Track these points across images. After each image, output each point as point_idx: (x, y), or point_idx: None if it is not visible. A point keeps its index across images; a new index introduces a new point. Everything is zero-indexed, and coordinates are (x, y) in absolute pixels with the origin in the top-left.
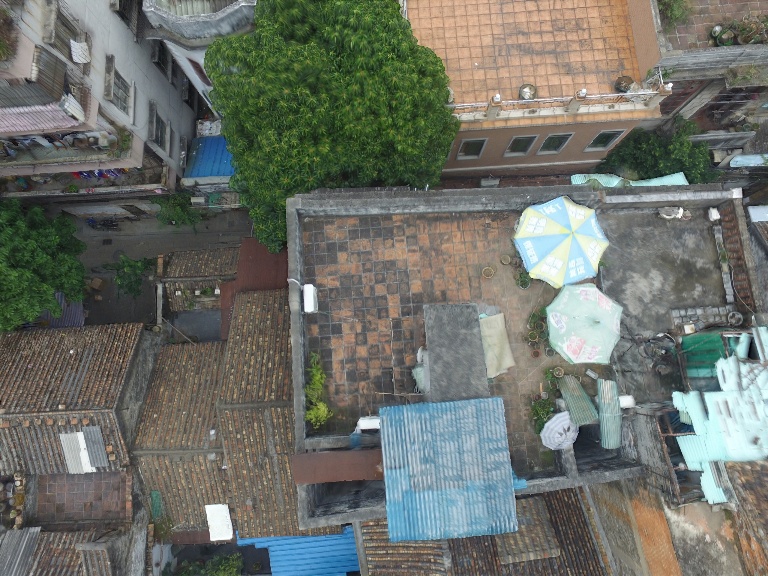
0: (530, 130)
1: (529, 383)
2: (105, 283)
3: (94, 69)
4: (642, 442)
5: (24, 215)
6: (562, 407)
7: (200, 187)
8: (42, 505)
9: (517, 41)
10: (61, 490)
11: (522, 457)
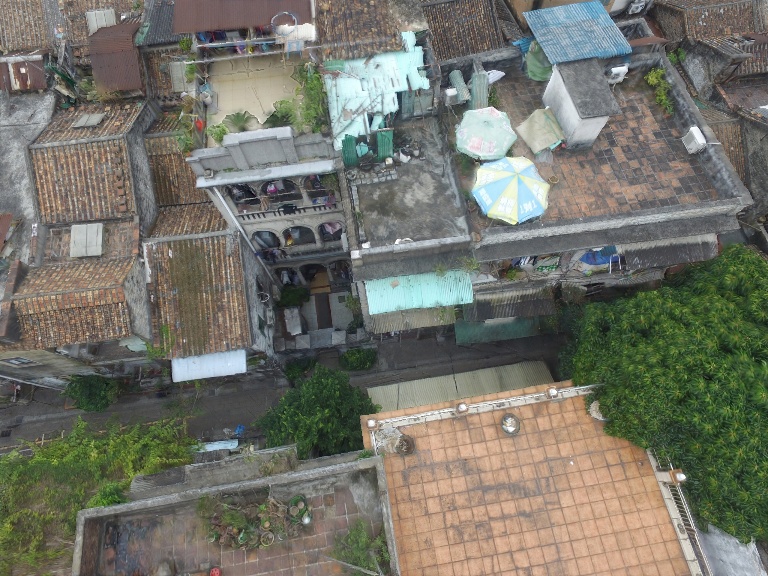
0: None
1: None
2: None
3: None
4: None
5: None
6: None
7: None
8: None
9: (530, 501)
10: None
11: (500, 80)
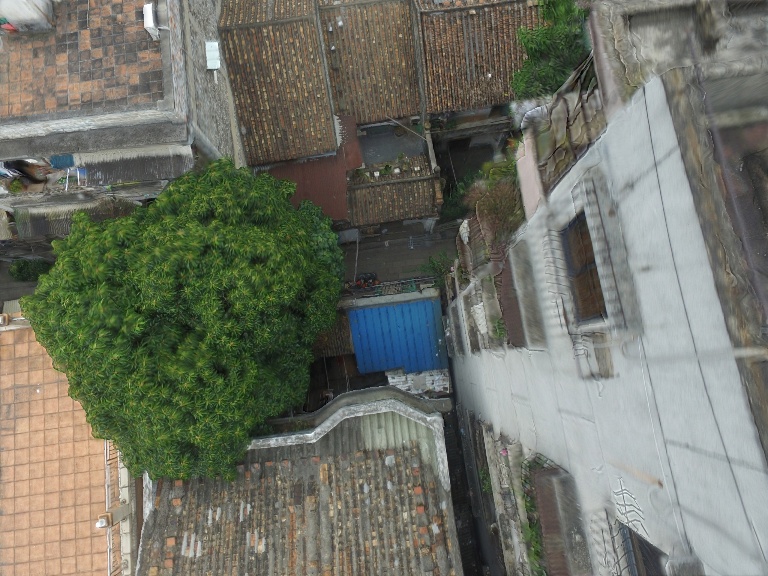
0: None
1: None
2: None
3: None
4: None
5: None
6: None
7: None
8: None
9: None
10: None
11: None
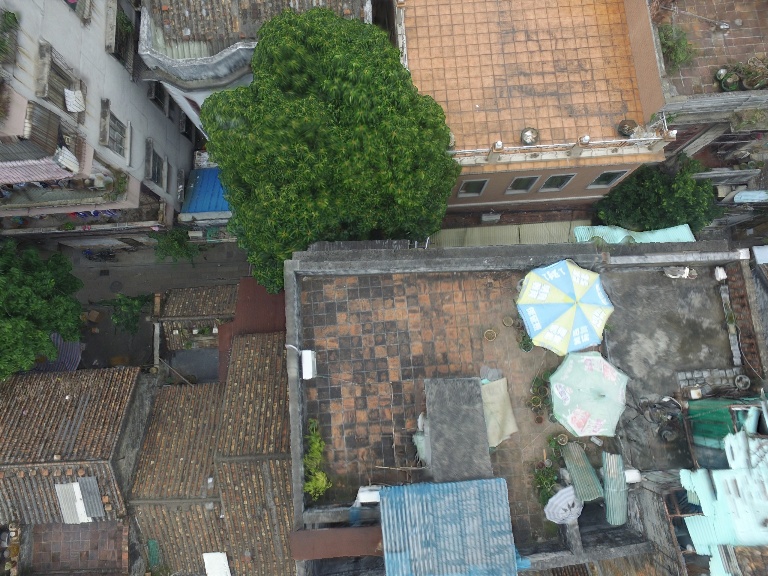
0: (532, 171)
1: (532, 449)
2: (102, 315)
3: (89, 116)
4: (648, 517)
5: (20, 248)
6: (566, 479)
7: (198, 222)
8: (37, 554)
9: (519, 82)
10: (57, 539)
11: (525, 527)
